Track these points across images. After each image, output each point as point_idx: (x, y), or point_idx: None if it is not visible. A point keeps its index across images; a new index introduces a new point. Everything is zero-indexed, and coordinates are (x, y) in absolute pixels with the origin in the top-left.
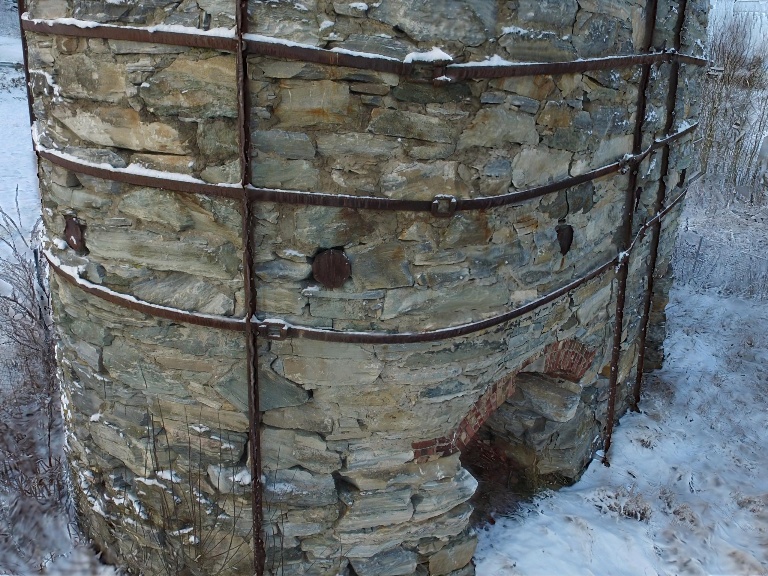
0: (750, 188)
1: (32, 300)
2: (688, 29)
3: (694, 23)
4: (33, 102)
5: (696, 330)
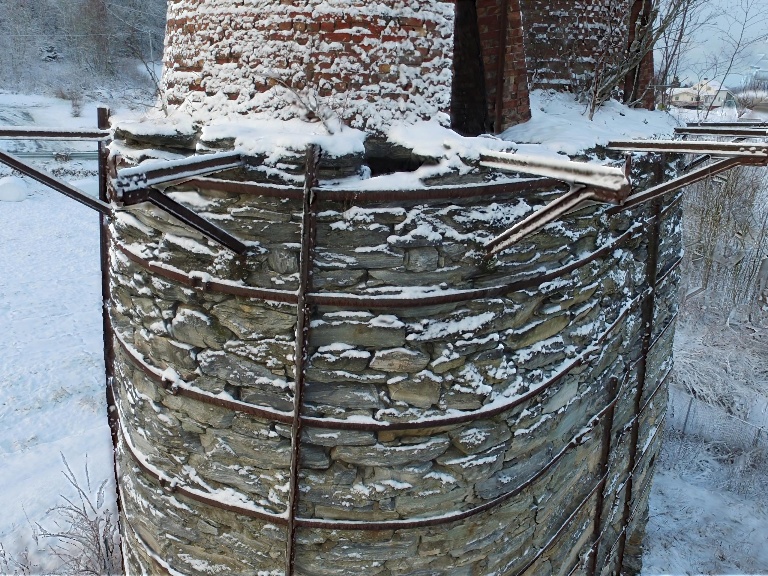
0: (748, 308)
1: (98, 554)
2: (651, 371)
3: (658, 359)
4: (119, 501)
5: (675, 536)
